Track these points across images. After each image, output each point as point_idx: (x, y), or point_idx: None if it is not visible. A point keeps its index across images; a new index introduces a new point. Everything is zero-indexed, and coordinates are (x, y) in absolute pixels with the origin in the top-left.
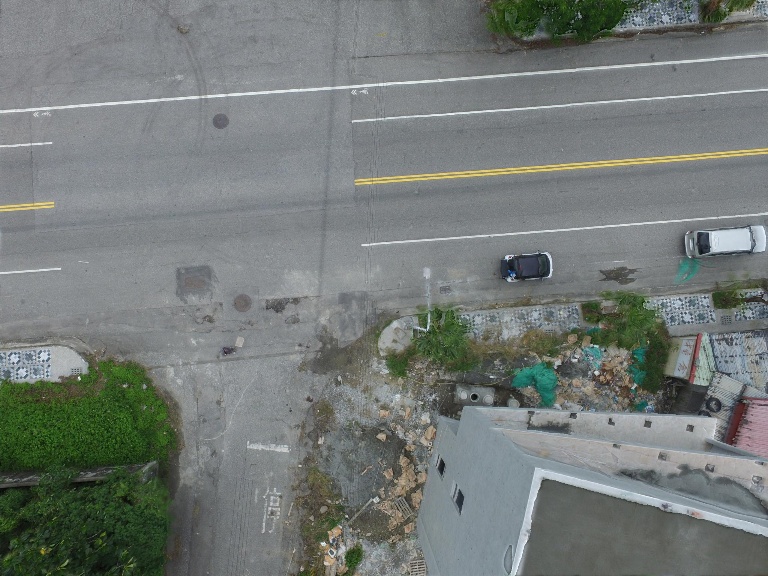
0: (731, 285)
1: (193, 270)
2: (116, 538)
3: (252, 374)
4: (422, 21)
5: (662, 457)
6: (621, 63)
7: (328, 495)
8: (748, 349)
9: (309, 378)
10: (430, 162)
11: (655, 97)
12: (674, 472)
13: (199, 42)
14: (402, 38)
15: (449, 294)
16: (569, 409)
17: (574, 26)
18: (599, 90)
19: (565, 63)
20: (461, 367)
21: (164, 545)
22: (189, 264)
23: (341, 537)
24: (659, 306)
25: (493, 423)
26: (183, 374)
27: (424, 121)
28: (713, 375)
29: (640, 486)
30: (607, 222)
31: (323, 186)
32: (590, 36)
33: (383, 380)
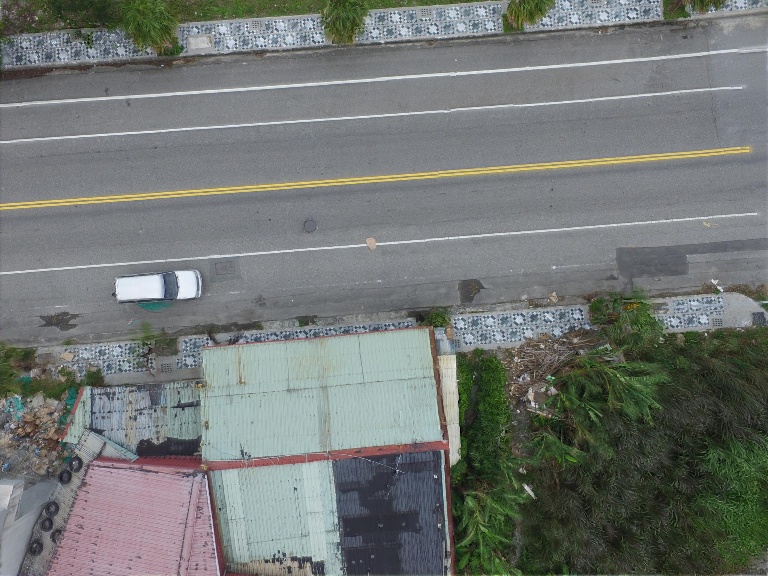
0: (178, 331)
1: None
2: None
3: None
4: None
5: None
6: (73, 97)
7: None
8: (129, 404)
9: None
10: None
11: (104, 133)
12: None
13: None
14: None
15: None
16: None
17: None
18: (47, 125)
19: (11, 97)
20: None
21: None
22: None
23: None
24: (96, 354)
25: None
26: None
27: None
28: (83, 432)
29: None
30: (47, 265)
31: None
32: None
33: None
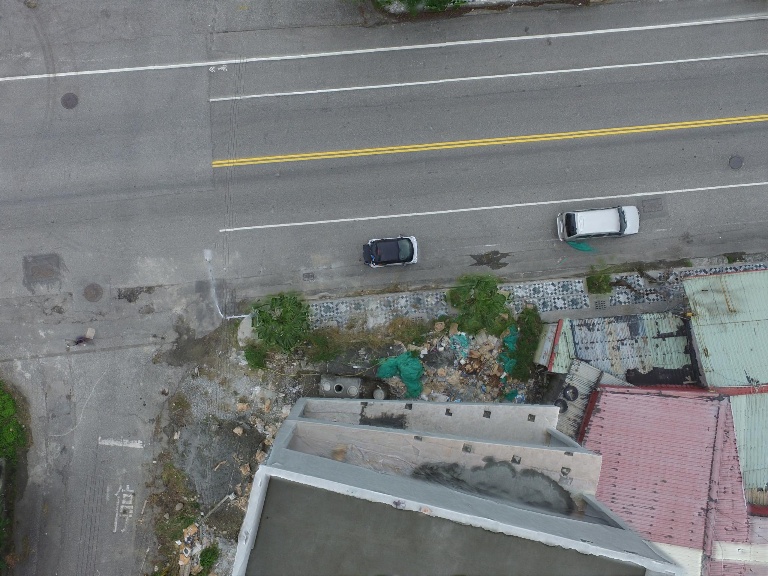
0: (607, 269)
1: (40, 258)
2: None
3: (104, 367)
4: None
5: (467, 449)
6: (494, 37)
7: (184, 492)
8: (610, 335)
9: (164, 370)
10: (292, 143)
11: (528, 72)
12: (479, 465)
13: (48, 17)
14: (263, 12)
15: (313, 281)
16: (435, 399)
17: None
18: (470, 65)
19: (435, 37)
20: (321, 357)
21: (12, 546)
22: (36, 252)
23: (197, 535)
24: (531, 291)
25: (296, 415)
26: (31, 368)
27: (286, 99)
28: (572, 362)
29: (412, 481)
30: (478, 204)
31: (179, 169)
32: (442, 6)
33: (242, 372)
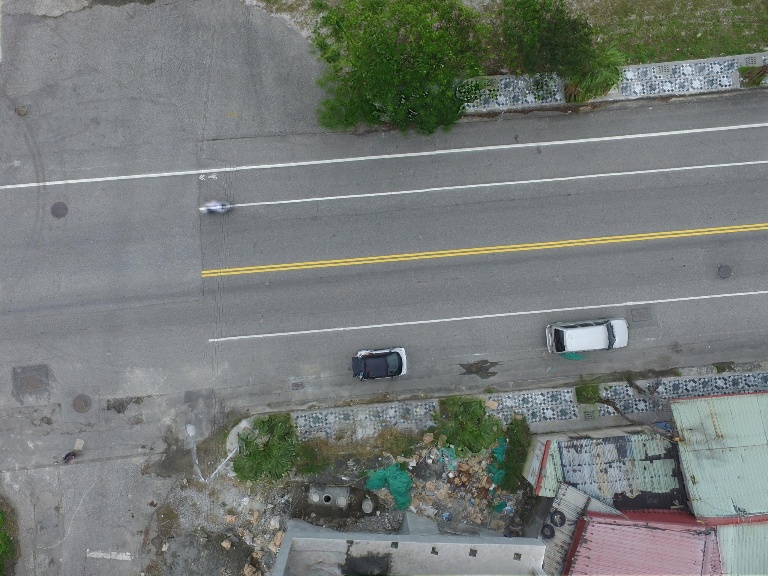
0: (596, 378)
1: (29, 369)
2: None
3: (92, 478)
4: (275, 100)
5: None
6: (484, 145)
7: None
8: (598, 457)
9: (153, 481)
10: (282, 252)
11: (518, 181)
12: None
13: (38, 125)
14: (254, 119)
15: (302, 390)
16: (423, 512)
17: (413, 119)
18: (460, 174)
19: (424, 145)
20: (310, 470)
21: None
22: (25, 363)
23: None
24: (520, 402)
25: None
26: (19, 479)
27: (276, 208)
28: (559, 486)
29: None
30: (467, 313)
31: (168, 278)
32: (430, 130)
33: (231, 482)
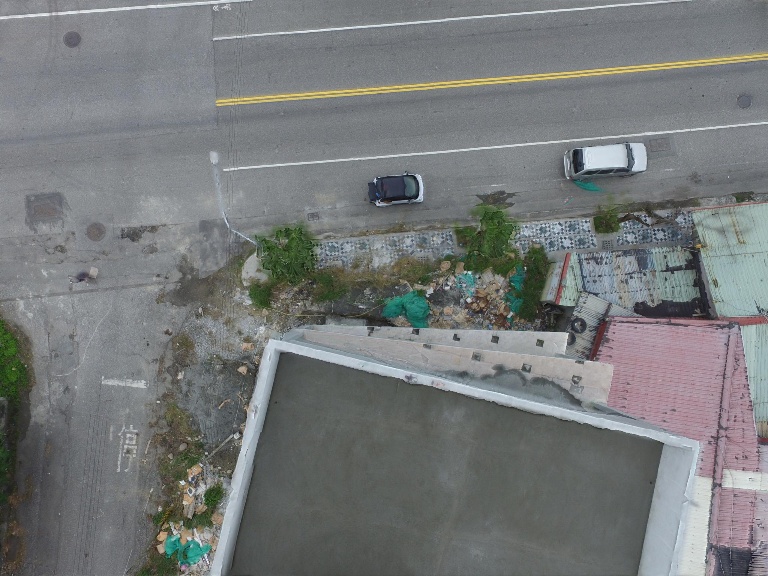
0: (614, 209)
1: (43, 197)
2: None
3: (107, 306)
4: None
5: (476, 358)
6: None
7: (188, 432)
8: (618, 268)
9: (168, 310)
10: (296, 82)
11: (535, 11)
12: (488, 373)
13: None
14: None
15: (317, 221)
16: None
17: None
18: (476, 4)
19: None
20: (326, 296)
21: (14, 486)
22: (38, 191)
23: (201, 475)
24: (538, 231)
25: None
26: (33, 307)
27: (290, 38)
28: (580, 295)
29: None
30: (484, 144)
31: (182, 108)
32: None
33: (247, 312)
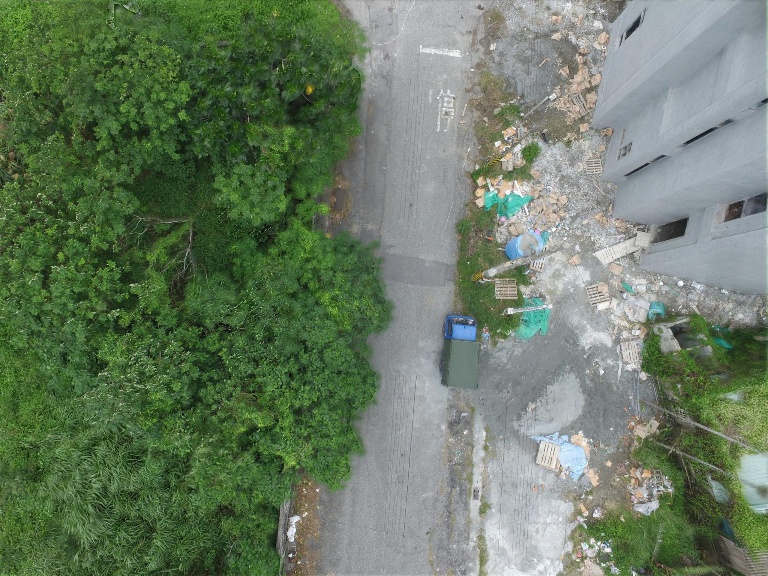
0: None
1: None
2: (322, 62)
3: None
4: None
5: None
6: None
7: (501, 98)
8: None
9: None
10: None
11: None
12: None
13: None
14: None
15: None
16: None
17: None
18: None
19: None
20: None
21: None
22: None
23: (516, 137)
24: None
25: None
26: None
27: None
28: None
29: None
30: None
31: None
32: None
33: None
